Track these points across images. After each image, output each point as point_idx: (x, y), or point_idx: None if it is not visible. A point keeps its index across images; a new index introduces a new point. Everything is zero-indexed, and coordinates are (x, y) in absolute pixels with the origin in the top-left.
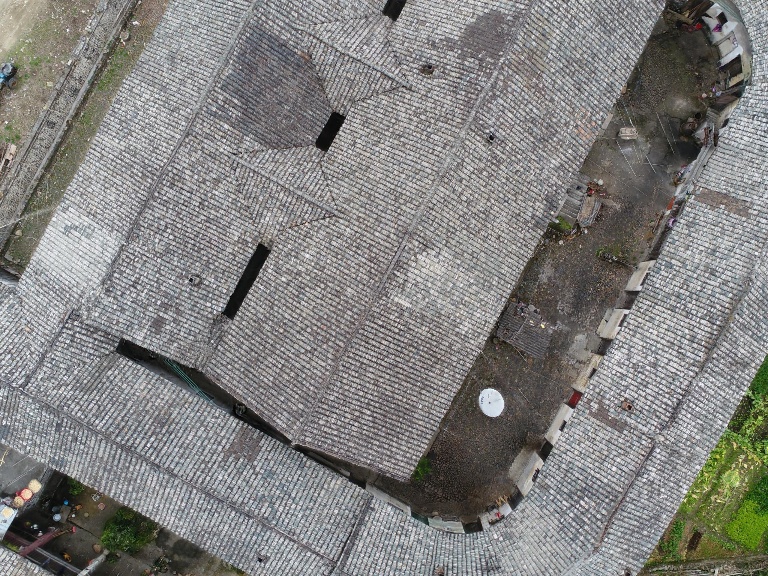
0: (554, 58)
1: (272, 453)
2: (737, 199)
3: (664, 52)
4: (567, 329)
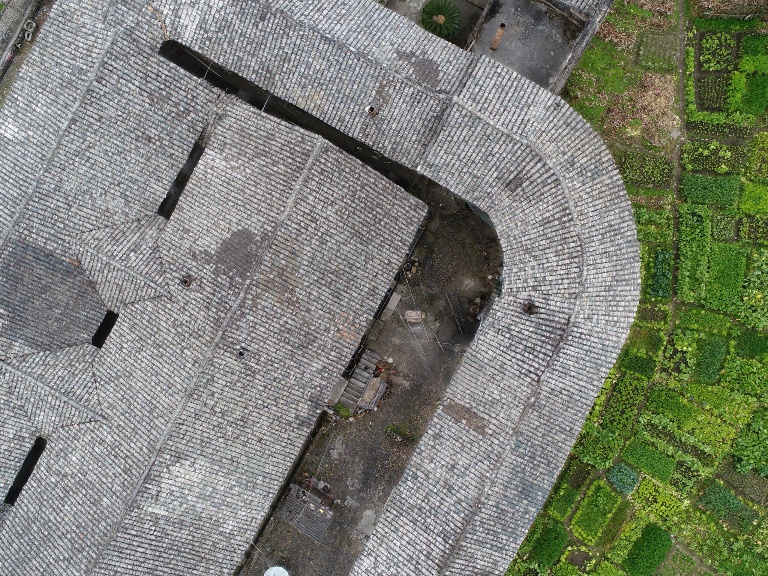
0: (307, 272)
1: None
2: (477, 415)
3: (454, 232)
4: (356, 504)
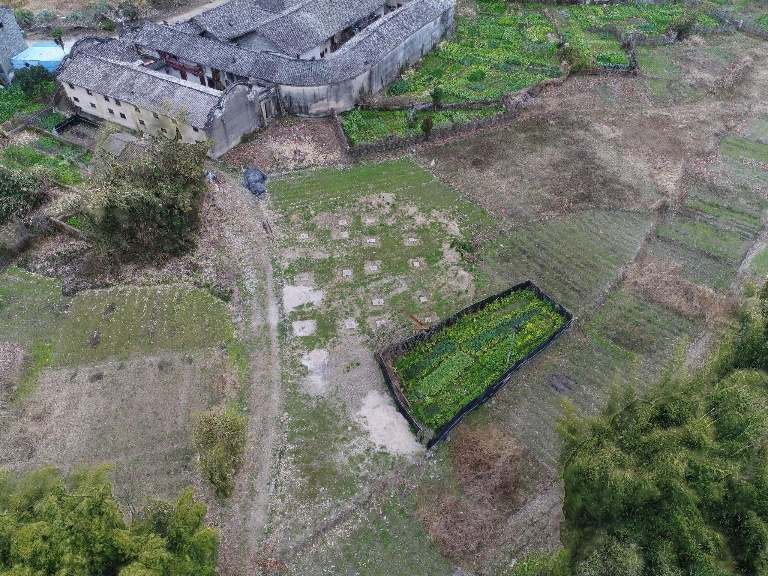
0: None
1: None
2: None
3: None
4: None
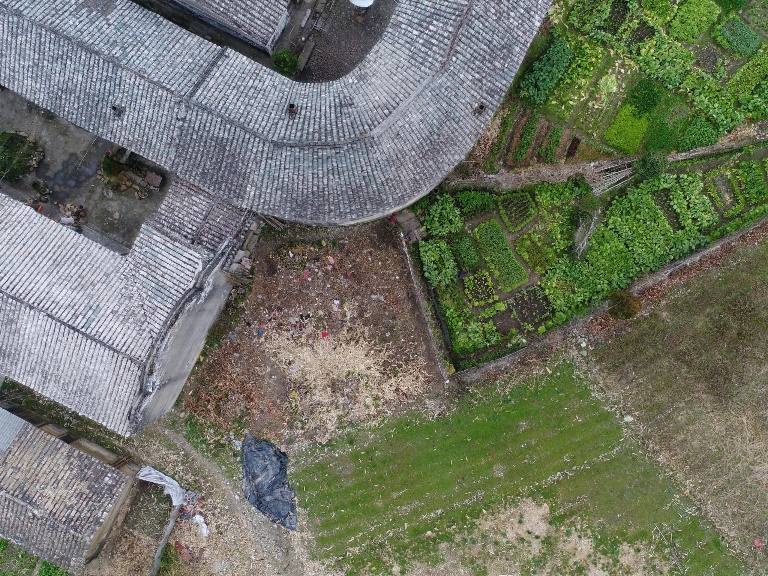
0: None
1: (127, 11)
2: None
3: None
4: None
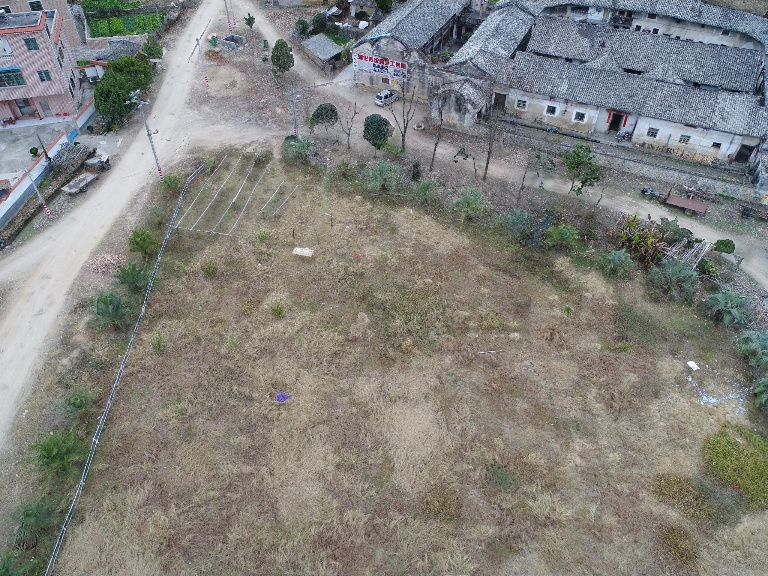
0: None
1: None
2: None
3: None
4: None
